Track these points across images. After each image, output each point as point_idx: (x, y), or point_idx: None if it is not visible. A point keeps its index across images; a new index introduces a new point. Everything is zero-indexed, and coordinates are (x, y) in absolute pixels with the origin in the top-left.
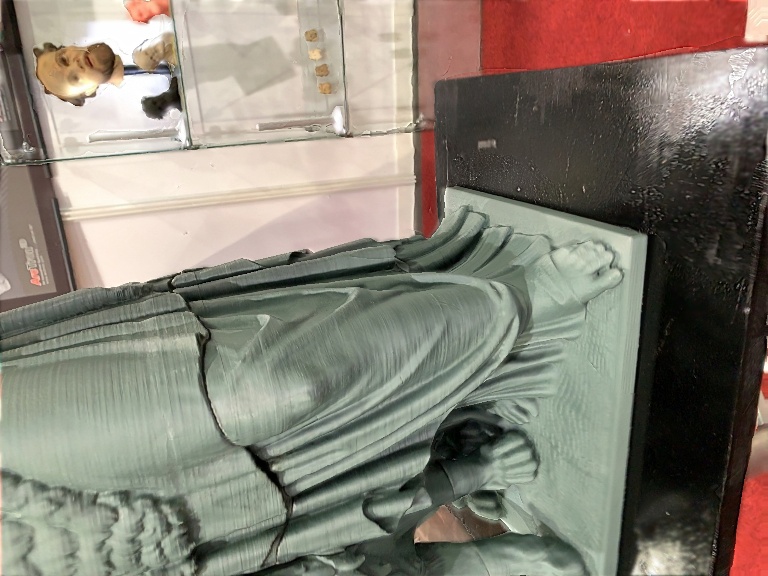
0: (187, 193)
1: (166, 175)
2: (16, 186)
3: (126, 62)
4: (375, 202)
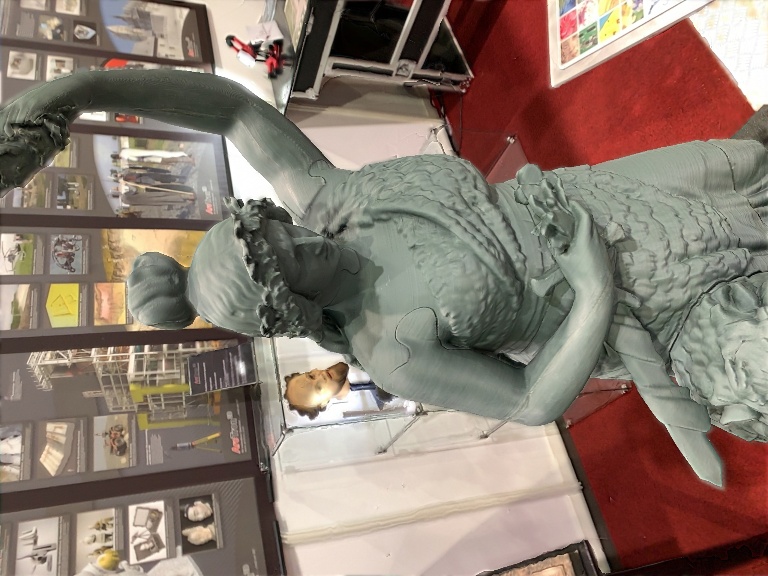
0: (384, 515)
1: (366, 497)
2: (245, 511)
3: (350, 380)
4: (552, 513)
